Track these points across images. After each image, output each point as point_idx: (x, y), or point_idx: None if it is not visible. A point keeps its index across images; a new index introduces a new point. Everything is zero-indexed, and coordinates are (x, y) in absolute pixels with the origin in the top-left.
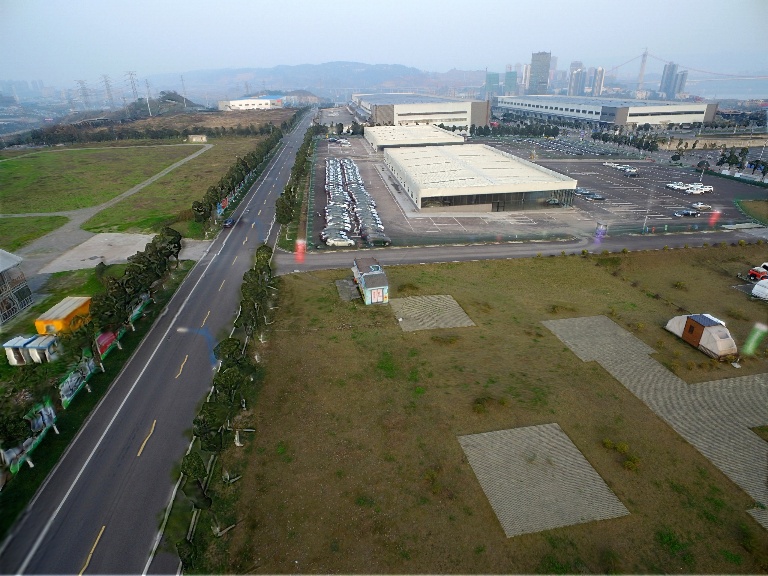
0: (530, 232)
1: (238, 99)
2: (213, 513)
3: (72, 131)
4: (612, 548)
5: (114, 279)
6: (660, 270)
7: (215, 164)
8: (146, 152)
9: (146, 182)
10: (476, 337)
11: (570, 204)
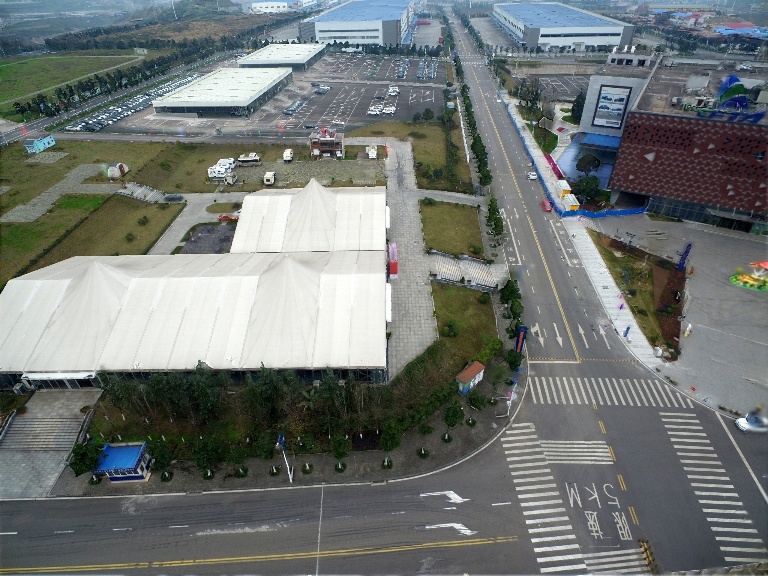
0: None
1: (260, 1)
2: None
3: (71, 40)
4: None
5: None
6: (215, 154)
7: (111, 75)
8: (93, 62)
9: (51, 87)
10: (45, 166)
11: (247, 116)
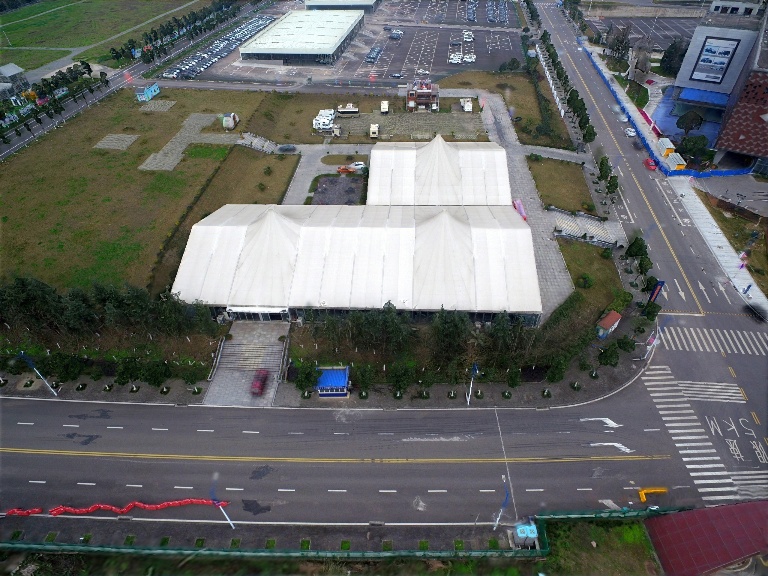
0: (277, 79)
1: None
2: (32, 133)
3: None
4: (111, 152)
5: (44, 80)
6: (310, 104)
7: None
8: (157, 2)
9: (129, 30)
10: None
11: (332, 64)
